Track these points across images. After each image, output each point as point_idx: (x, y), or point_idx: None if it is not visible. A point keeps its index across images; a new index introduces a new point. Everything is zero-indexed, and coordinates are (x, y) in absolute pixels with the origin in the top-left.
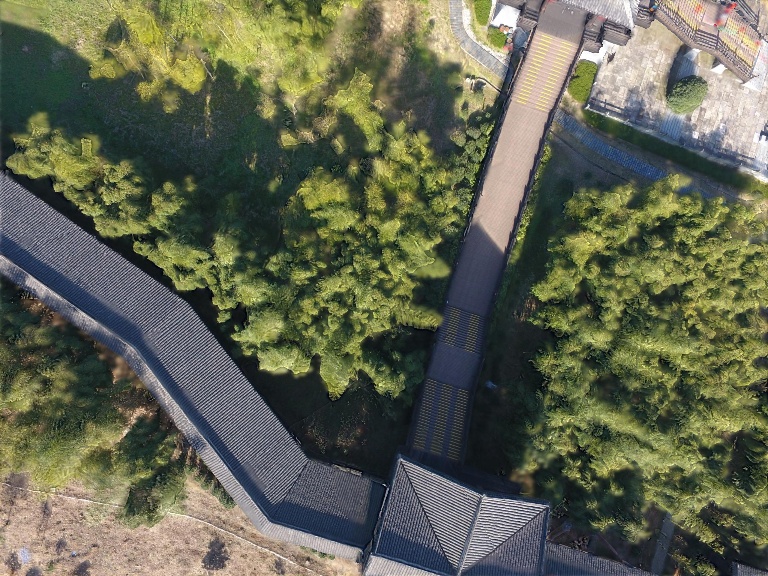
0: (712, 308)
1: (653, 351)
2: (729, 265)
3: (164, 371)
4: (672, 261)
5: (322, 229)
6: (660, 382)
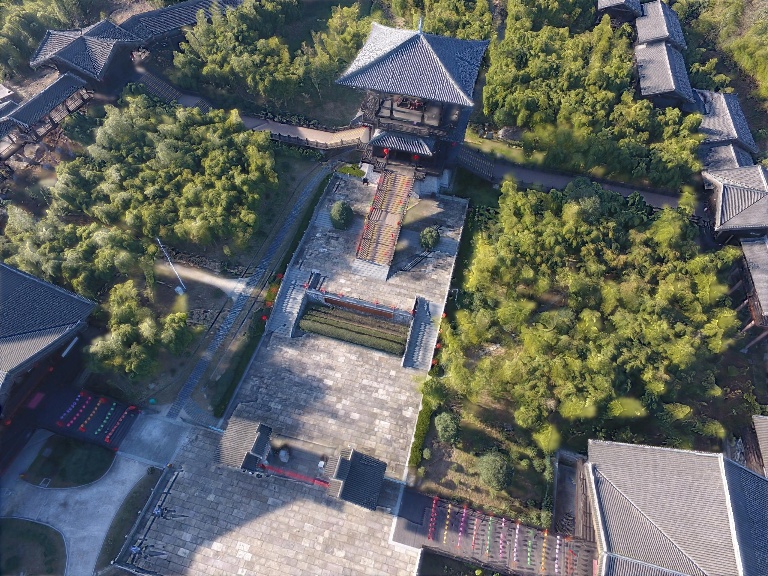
0: None
1: None
2: None
3: (205, 0)
4: (219, 160)
5: None
6: None
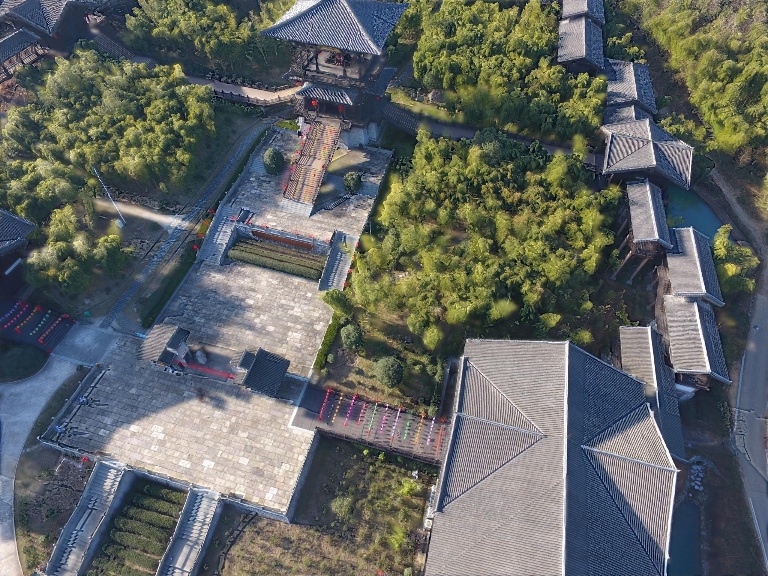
0: None
1: None
2: None
3: None
4: (159, 108)
5: None
6: None
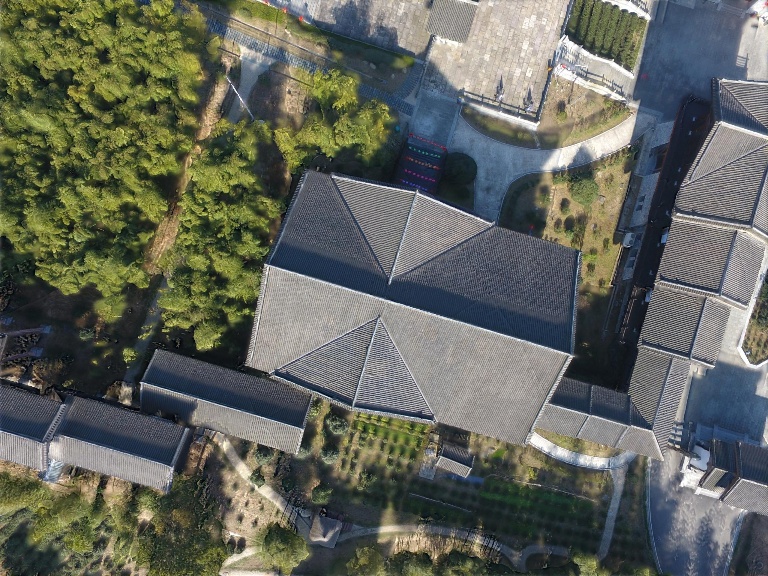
0: (114, 95)
1: (5, 121)
2: (122, 50)
3: None
4: (47, 42)
5: None
6: (53, 165)
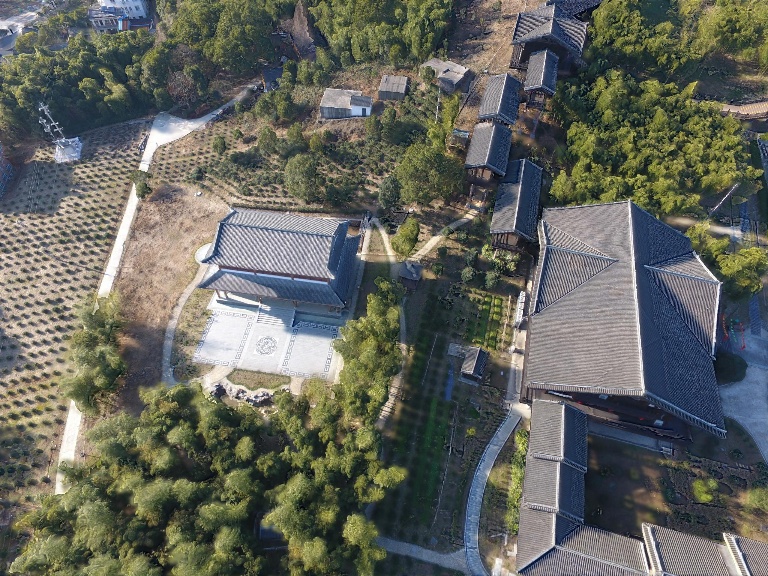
0: None
1: None
2: None
3: None
4: (704, 124)
5: (652, 26)
6: None
